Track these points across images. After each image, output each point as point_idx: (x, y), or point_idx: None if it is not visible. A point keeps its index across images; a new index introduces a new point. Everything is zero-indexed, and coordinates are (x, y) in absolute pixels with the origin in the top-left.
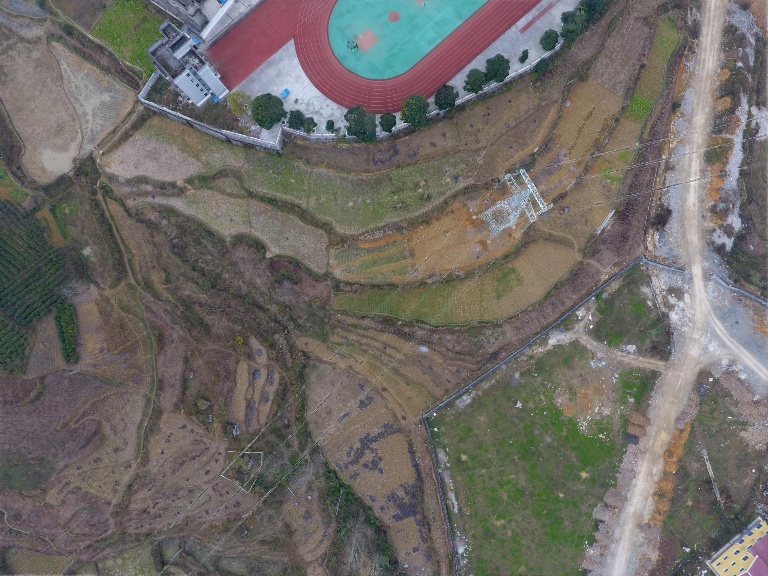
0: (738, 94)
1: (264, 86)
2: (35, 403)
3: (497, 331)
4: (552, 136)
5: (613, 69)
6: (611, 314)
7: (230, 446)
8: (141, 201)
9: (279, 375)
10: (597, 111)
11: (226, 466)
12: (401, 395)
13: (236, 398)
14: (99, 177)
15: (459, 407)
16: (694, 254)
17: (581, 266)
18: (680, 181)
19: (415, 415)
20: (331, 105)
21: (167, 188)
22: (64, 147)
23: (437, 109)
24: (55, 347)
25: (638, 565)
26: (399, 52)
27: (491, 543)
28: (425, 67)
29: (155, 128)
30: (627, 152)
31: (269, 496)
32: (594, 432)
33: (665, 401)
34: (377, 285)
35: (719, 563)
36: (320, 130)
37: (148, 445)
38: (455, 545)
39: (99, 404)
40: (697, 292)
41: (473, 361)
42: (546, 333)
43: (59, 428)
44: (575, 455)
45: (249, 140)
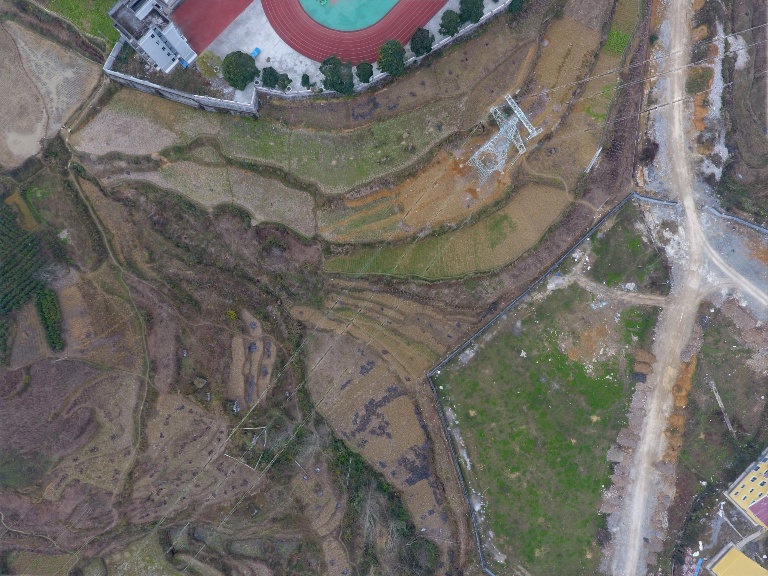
0: (714, 23)
1: (233, 47)
2: (23, 395)
3: (494, 281)
4: (532, 77)
5: (588, 4)
6: (607, 253)
7: (232, 423)
8: (116, 179)
9: (276, 347)
10: (575, 48)
11: (229, 444)
12: (403, 356)
13: (233, 374)
14: (69, 157)
15: (463, 362)
16: (684, 186)
17: (573, 207)
18: (664, 114)
19: (419, 375)
20: (304, 61)
21: (142, 163)
22: (29, 129)
23: (414, 56)
24: (38, 335)
25: (657, 503)
26: (370, 1)
27: (507, 497)
28: (398, 15)
29: (124, 101)
30: (609, 88)
31: (276, 471)
32: (601, 374)
33: (669, 336)
34: (368, 244)
35: (737, 492)
36: (295, 87)
37: (146, 429)
38: (471, 503)
39: (90, 391)
40: (691, 224)
41: (473, 313)
42: (544, 278)
43: (50, 419)
44: (584, 399)
45: (223, 104)
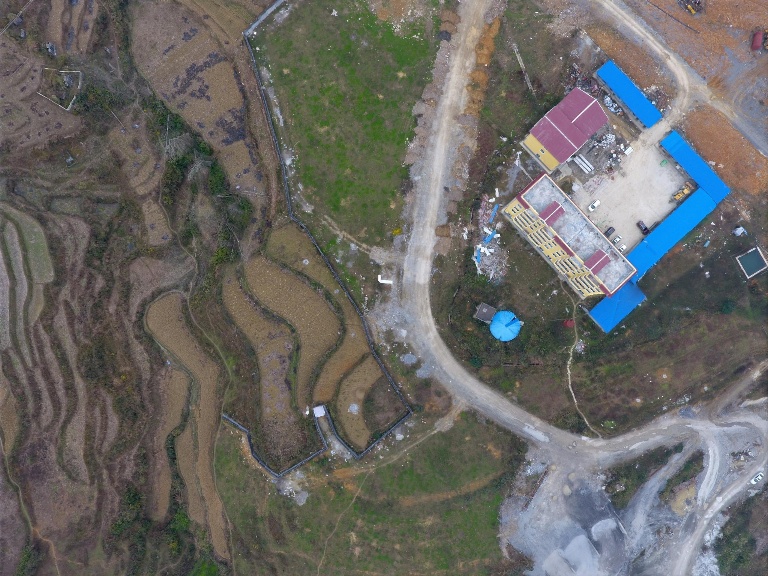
0: None
1: None
2: None
3: None
4: None
5: None
6: None
7: (46, 64)
8: None
9: (98, 4)
10: None
11: (43, 85)
12: (222, 19)
13: (52, 21)
14: None
15: (278, 22)
16: None
17: None
18: None
19: (237, 37)
20: None
21: None
22: None
23: None
24: None
25: (457, 154)
26: None
27: (316, 150)
28: None
29: None
30: None
31: (91, 117)
32: (408, 33)
33: None
34: None
35: (529, 135)
36: None
37: None
38: (282, 157)
39: None
40: None
41: None
42: None
43: None
44: (391, 56)
45: None
